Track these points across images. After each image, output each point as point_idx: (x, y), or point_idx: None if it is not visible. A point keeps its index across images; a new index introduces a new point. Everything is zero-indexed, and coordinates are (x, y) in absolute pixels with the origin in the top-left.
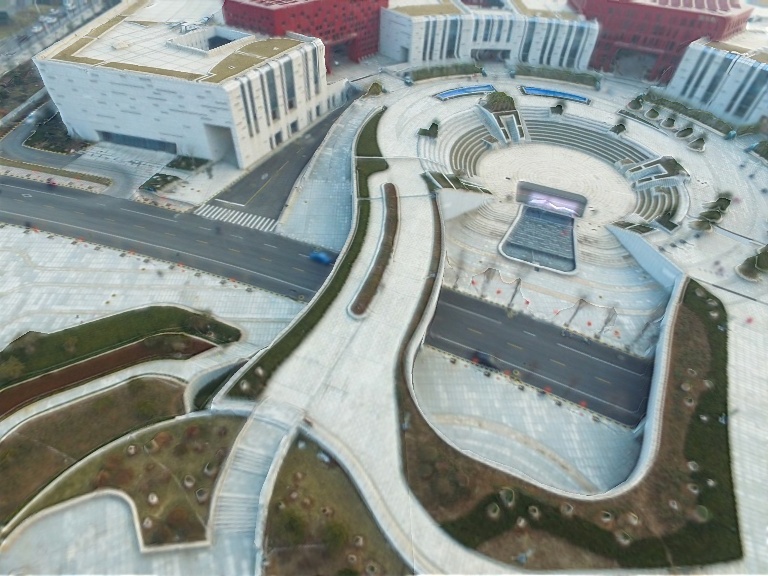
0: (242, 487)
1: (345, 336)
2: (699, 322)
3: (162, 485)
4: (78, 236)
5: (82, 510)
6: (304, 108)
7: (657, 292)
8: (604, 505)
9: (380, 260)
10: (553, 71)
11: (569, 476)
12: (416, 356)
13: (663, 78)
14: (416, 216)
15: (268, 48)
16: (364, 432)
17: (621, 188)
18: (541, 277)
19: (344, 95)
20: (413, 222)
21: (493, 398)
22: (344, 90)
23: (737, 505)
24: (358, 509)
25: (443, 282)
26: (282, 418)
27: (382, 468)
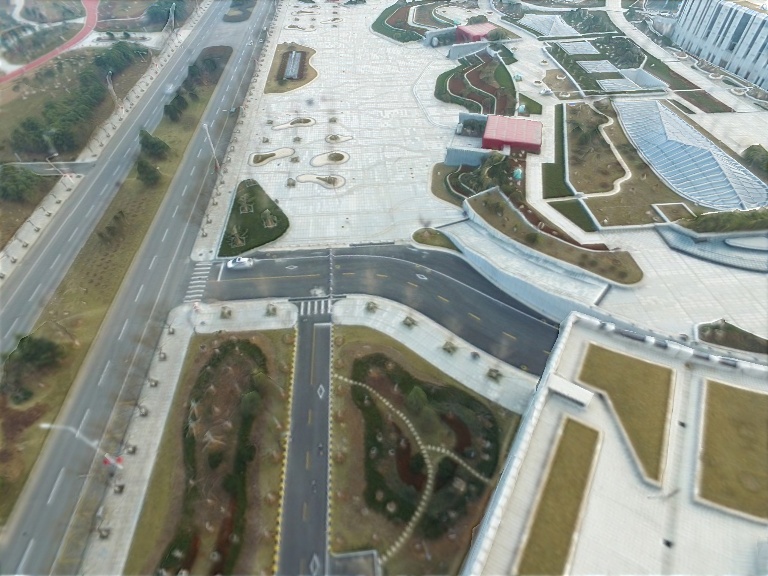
0: (484, 3)
1: None
2: None
3: (464, 5)
4: None
5: None
6: None
7: None
8: None
9: None
10: None
11: None
12: None
13: None
14: None
15: None
16: None
17: None
18: None
19: None
20: None
21: None
22: None
23: (606, 2)
24: None
25: None
26: None
27: None
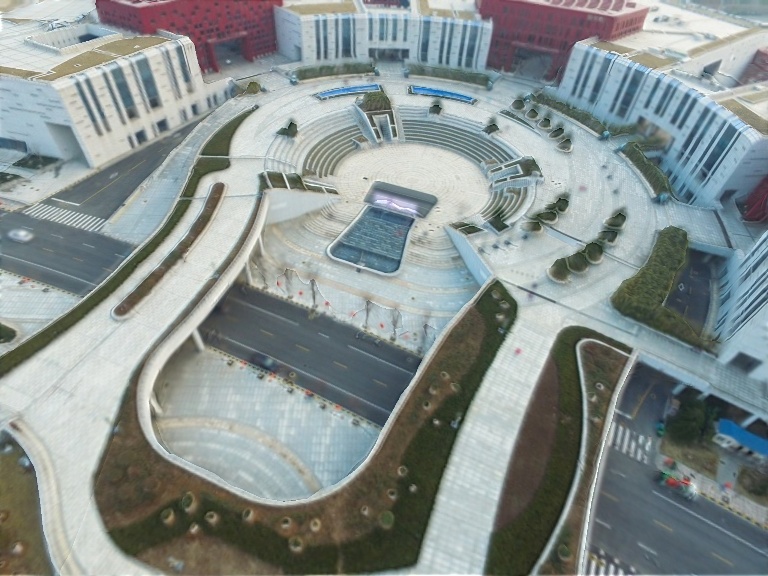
0: None
1: (98, 337)
2: (482, 324)
3: None
4: None
5: None
6: (174, 107)
7: (473, 294)
8: (294, 511)
9: (167, 260)
10: (448, 71)
11: (302, 480)
12: None
13: (556, 78)
14: (232, 216)
15: (129, 46)
16: (72, 435)
17: (478, 188)
18: (360, 278)
19: (228, 94)
20: (226, 222)
21: (256, 401)
22: (228, 89)
23: (433, 511)
24: (35, 514)
25: (251, 283)
26: None
27: (74, 472)
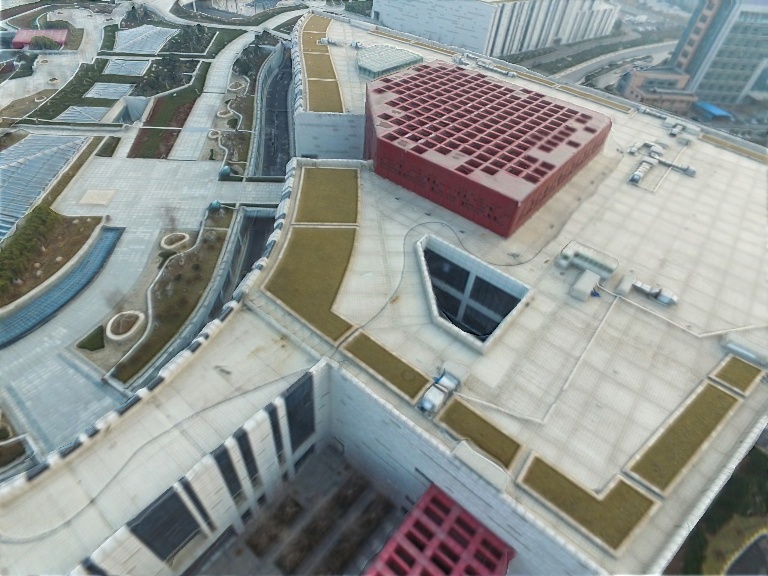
0: None
1: None
2: (294, 7)
3: (99, 9)
4: None
5: (76, 10)
6: None
7: None
8: None
9: None
10: None
11: None
12: (188, 7)
13: None
14: None
15: None
16: None
17: None
18: None
19: None
20: None
21: None
22: None
23: (265, 22)
24: None
25: (213, 6)
26: (136, 2)
27: (164, 10)
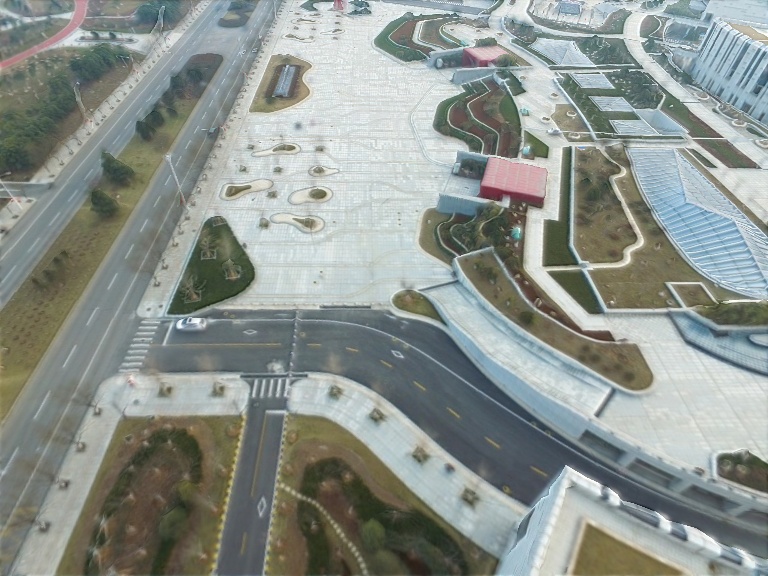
0: None
1: (509, 8)
2: None
3: None
4: (395, 3)
5: (457, 26)
6: None
7: None
8: None
9: None
10: None
11: None
12: None
13: None
14: None
15: None
16: None
17: (600, 0)
18: (568, 16)
19: None
20: None
21: None
22: None
23: (624, 29)
24: None
25: None
26: None
27: None
